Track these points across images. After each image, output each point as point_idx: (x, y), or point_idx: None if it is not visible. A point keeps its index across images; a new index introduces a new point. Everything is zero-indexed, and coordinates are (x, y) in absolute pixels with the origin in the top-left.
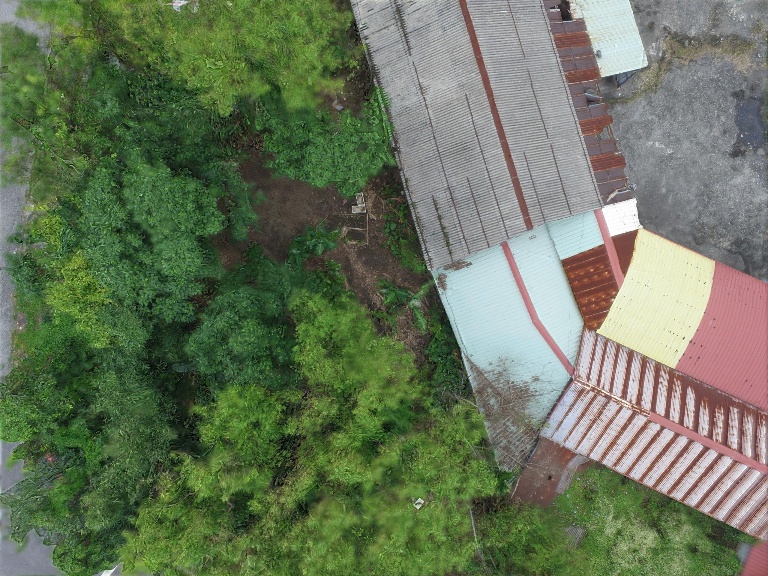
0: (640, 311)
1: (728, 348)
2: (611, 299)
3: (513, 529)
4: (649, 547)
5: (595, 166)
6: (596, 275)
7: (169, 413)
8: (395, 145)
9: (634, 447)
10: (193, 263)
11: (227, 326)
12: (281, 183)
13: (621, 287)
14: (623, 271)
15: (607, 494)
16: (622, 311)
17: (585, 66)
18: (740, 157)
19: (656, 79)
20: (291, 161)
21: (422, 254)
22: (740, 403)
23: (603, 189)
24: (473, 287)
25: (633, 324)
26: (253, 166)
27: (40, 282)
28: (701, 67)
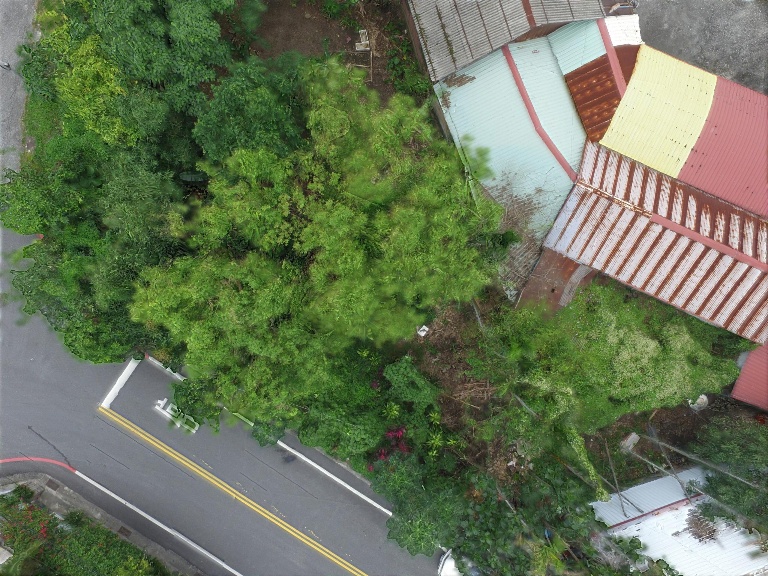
0: (642, 120)
1: (729, 155)
2: (613, 108)
3: (517, 313)
4: (651, 357)
5: None
6: (598, 85)
7: (177, 221)
8: None
9: (636, 252)
10: (201, 34)
11: (235, 95)
12: (285, 21)
13: (623, 96)
14: (625, 80)
15: (609, 308)
16: (624, 120)
17: None
18: None
19: None
20: None
21: (426, 79)
22: (741, 211)
23: (605, 1)
24: (477, 102)
25: (635, 133)
26: (257, 3)
27: (49, 77)
28: None
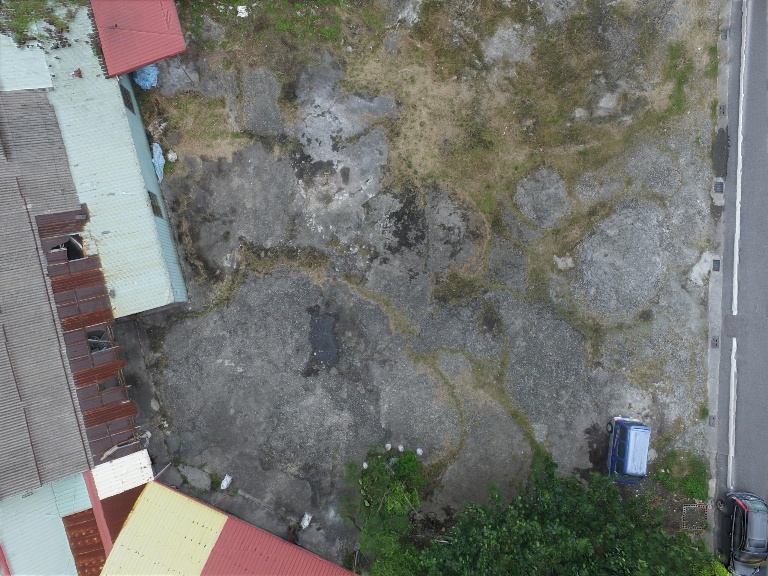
0: None
1: None
2: (99, 567)
3: None
4: None
5: (90, 422)
6: (87, 540)
7: None
8: None
9: None
10: None
11: None
12: None
13: (109, 555)
14: (112, 537)
15: None
16: None
17: (93, 308)
18: (312, 377)
19: (228, 293)
20: None
21: None
22: None
23: (98, 446)
24: None
25: None
26: None
27: None
28: (276, 280)
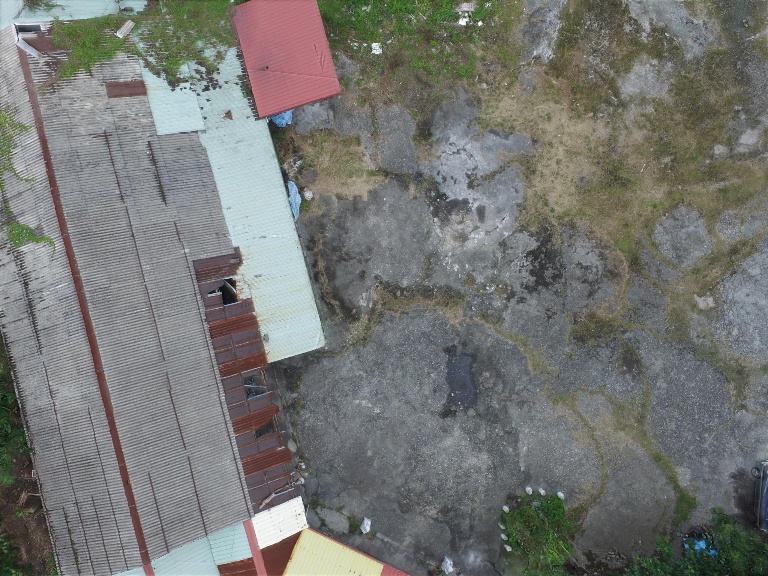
0: None
1: None
2: None
3: None
4: None
5: (248, 469)
6: None
7: None
8: (30, 446)
9: None
10: None
11: None
12: None
13: None
14: None
15: None
16: None
17: (248, 353)
18: (450, 418)
19: (365, 332)
20: None
21: None
22: None
23: (256, 494)
24: None
25: None
26: None
27: None
28: (412, 320)
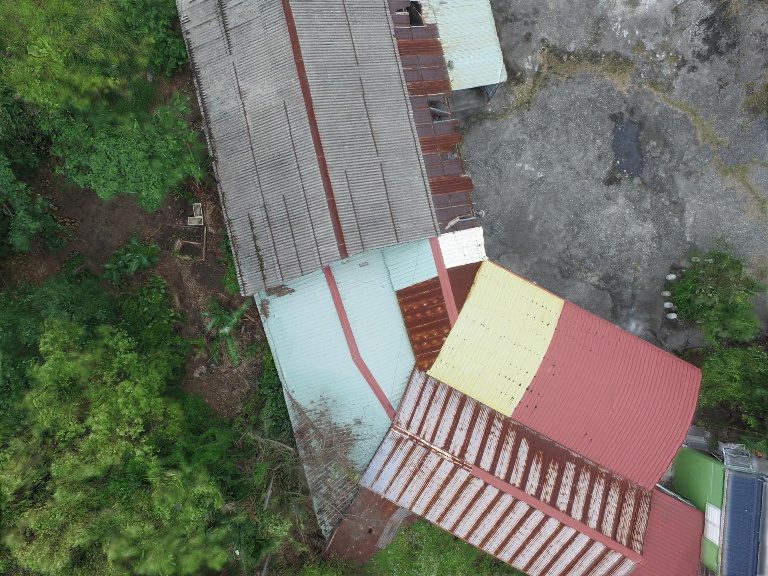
0: (474, 352)
1: (567, 398)
2: (443, 338)
3: None
4: None
5: (435, 189)
6: (429, 310)
7: None
8: (213, 154)
9: (458, 503)
10: None
11: None
12: None
13: (454, 325)
14: (457, 307)
15: (434, 550)
16: (455, 351)
17: (433, 77)
18: (615, 185)
19: (530, 95)
20: (80, 167)
21: None
22: (579, 458)
23: (442, 215)
24: (295, 316)
25: (466, 366)
26: None
27: None
28: (579, 85)
